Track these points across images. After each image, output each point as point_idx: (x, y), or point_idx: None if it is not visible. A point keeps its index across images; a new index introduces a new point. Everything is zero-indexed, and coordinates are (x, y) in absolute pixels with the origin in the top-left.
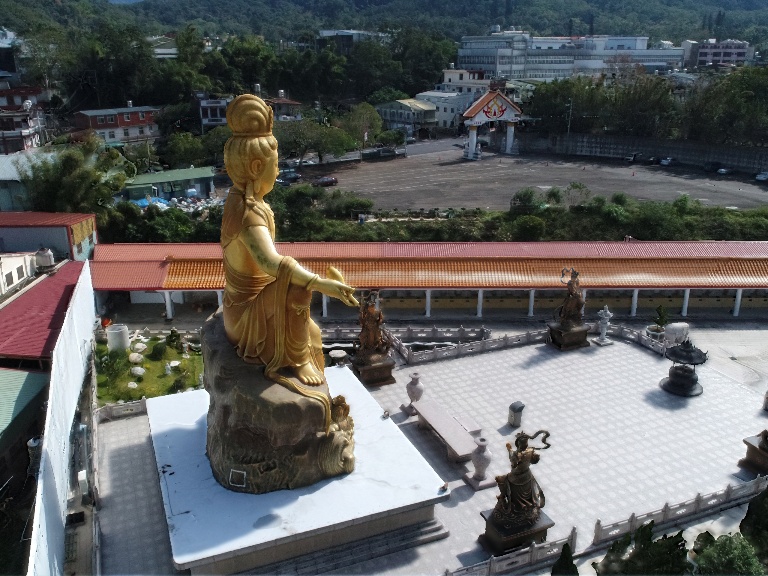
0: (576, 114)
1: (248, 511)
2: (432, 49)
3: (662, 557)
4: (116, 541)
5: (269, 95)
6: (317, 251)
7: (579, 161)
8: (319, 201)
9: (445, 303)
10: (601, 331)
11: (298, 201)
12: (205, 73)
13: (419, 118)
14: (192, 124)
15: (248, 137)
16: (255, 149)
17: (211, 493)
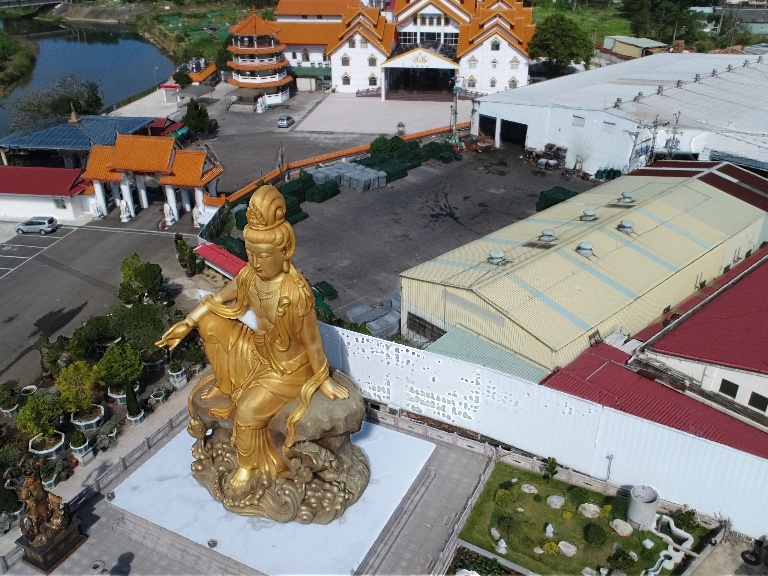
0: None
1: None
2: None
3: None
4: None
5: None
6: None
7: None
8: None
9: None
10: None
11: None
12: None
13: None
14: None
15: None
16: None
17: None
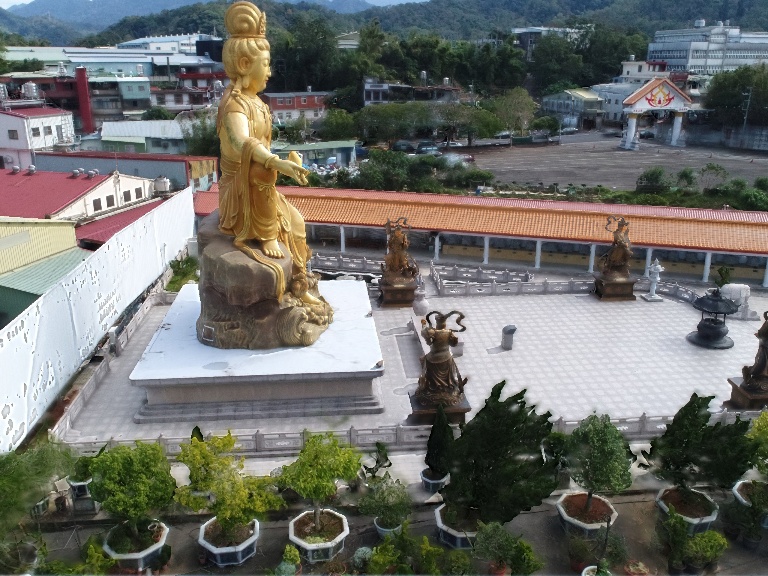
0: (755, 104)
1: (206, 357)
2: (618, 43)
3: (498, 409)
4: (117, 376)
5: (435, 82)
6: None
7: (752, 155)
8: (440, 170)
9: (508, 254)
10: (650, 286)
11: (420, 169)
12: (382, 63)
13: (579, 106)
14: (356, 106)
15: (239, 37)
16: (242, 47)
17: (187, 344)
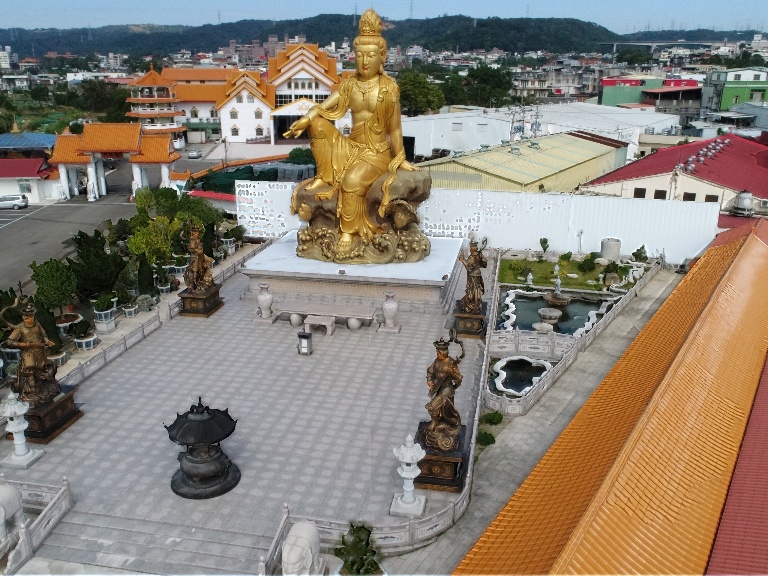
0: None
1: None
2: None
3: None
4: None
5: None
6: None
7: None
8: None
9: None
10: None
11: None
12: None
13: None
14: None
15: None
16: None
17: None
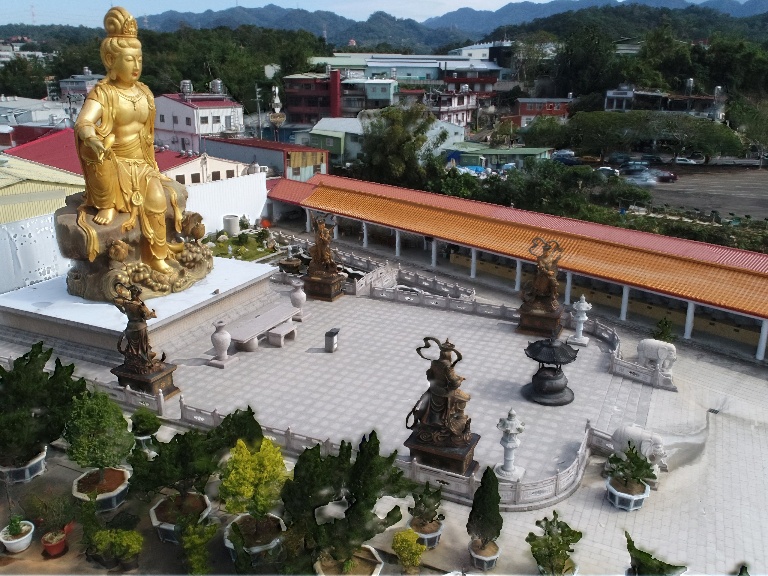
0: None
1: None
2: None
3: None
4: None
5: (705, 91)
6: (442, 203)
7: None
8: (592, 184)
9: (504, 272)
10: None
11: (569, 181)
12: (664, 70)
13: None
14: None
15: (108, 37)
16: (107, 45)
17: (60, 286)
